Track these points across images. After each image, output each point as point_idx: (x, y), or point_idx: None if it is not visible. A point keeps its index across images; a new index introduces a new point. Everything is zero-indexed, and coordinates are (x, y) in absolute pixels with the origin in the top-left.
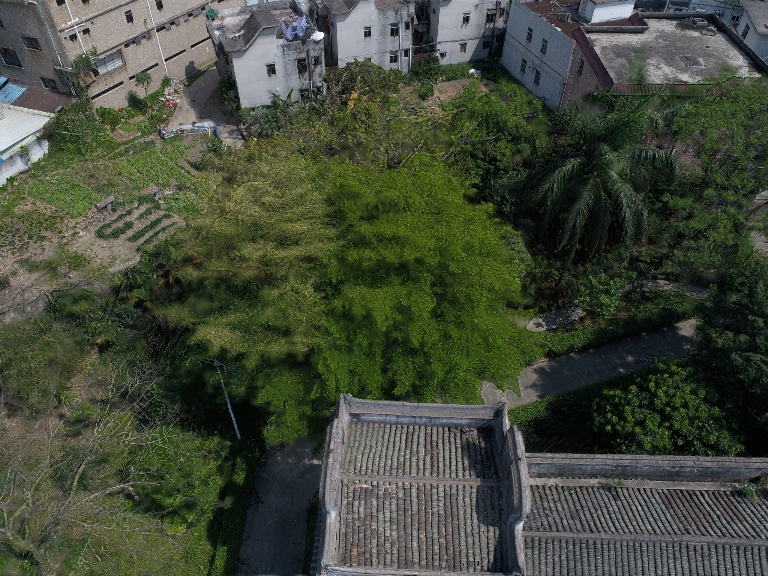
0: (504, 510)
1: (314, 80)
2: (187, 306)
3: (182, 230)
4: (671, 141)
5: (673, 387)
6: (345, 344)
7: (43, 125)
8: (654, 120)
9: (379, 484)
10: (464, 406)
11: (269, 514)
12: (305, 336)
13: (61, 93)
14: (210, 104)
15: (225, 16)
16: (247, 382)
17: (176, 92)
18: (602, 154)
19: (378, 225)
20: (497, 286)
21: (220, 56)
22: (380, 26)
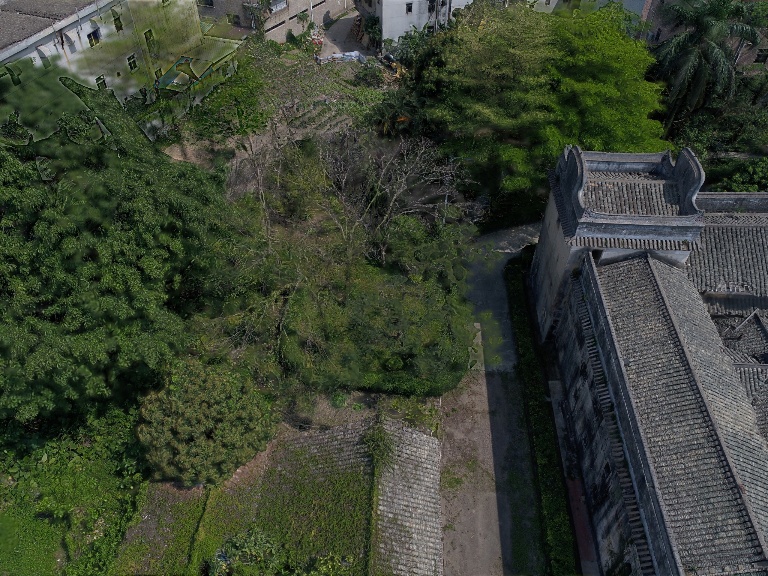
0: (681, 196)
1: (439, 19)
2: (393, 152)
3: (388, 98)
4: (751, 24)
5: (766, 168)
6: (562, 119)
7: (236, 48)
8: (740, 6)
9: (603, 183)
10: (643, 154)
11: (475, 276)
12: (540, 111)
13: (242, 27)
14: (348, 42)
15: None
16: (488, 156)
17: (319, 34)
18: (709, 24)
19: (586, 41)
20: None
21: (358, 3)
22: None
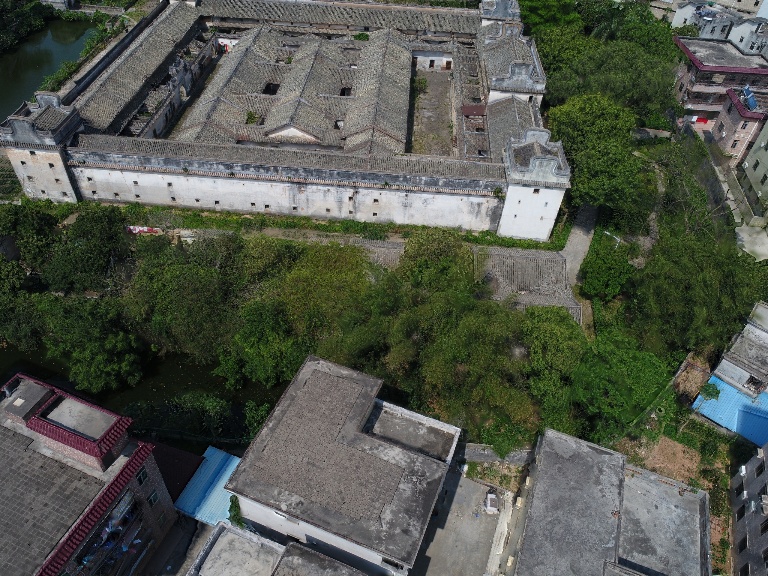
0: None
1: None
2: None
3: None
4: None
5: None
6: None
7: None
8: None
9: None
10: None
11: None
12: None
13: None
14: None
15: (716, 8)
16: None
17: None
18: None
19: None
20: (549, 2)
21: None
22: (748, 40)
